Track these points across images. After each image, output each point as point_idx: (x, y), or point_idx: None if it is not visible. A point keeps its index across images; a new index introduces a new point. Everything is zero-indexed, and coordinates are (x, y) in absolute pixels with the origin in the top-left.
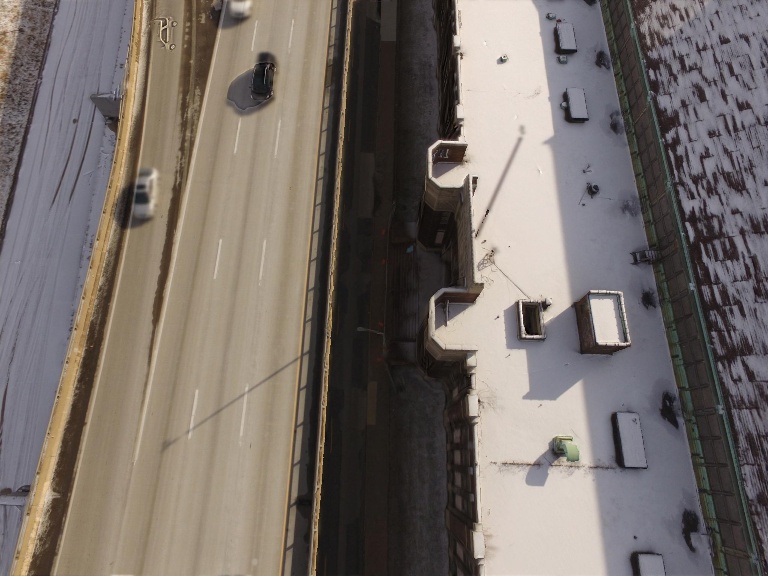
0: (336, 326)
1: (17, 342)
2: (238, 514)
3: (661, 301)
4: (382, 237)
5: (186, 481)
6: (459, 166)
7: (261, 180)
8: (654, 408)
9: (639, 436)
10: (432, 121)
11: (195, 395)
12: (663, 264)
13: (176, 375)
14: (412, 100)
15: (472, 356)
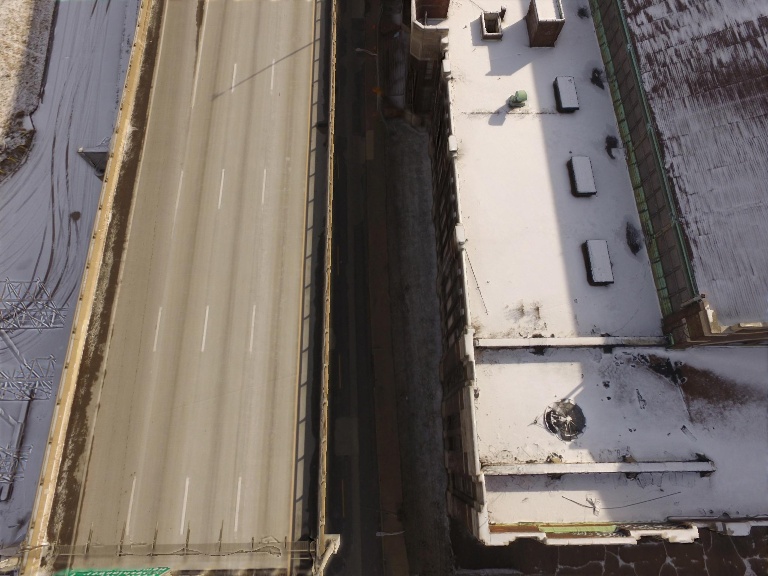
0: (338, 94)
1: (73, 113)
2: (273, 133)
3: (592, 12)
4: (373, 30)
5: (232, 116)
6: None
7: None
8: (586, 78)
9: (573, 90)
10: None
11: (234, 67)
12: None
13: (218, 56)
14: None
15: (445, 37)
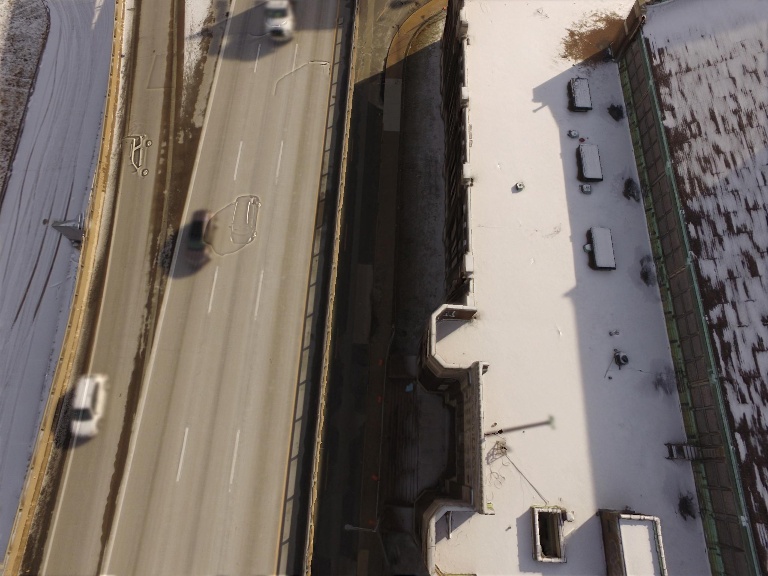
0: (324, 479)
1: None
2: None
3: (702, 511)
4: (379, 369)
5: None
6: (467, 324)
7: (237, 349)
8: None
9: None
10: (437, 228)
11: None
12: (704, 465)
13: None
14: (416, 203)
15: None
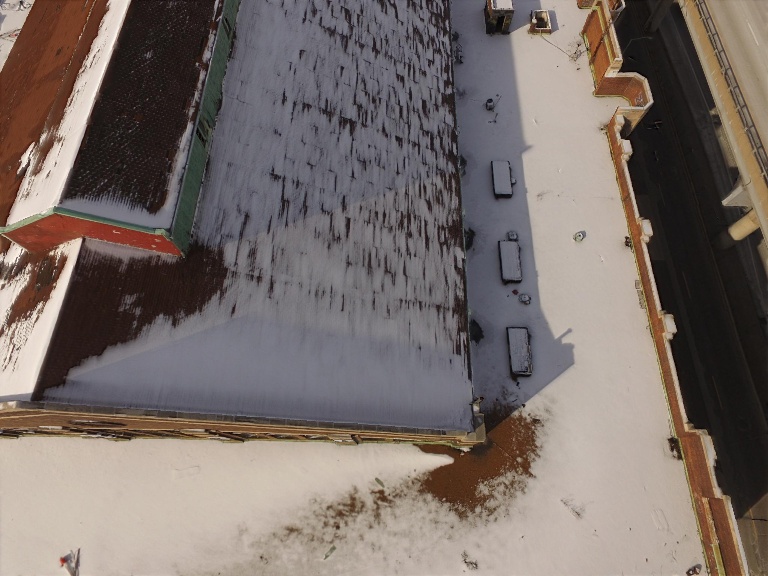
0: None
1: None
2: None
3: None
4: None
5: None
6: None
7: None
8: None
9: None
10: None
11: None
12: None
13: None
14: None
15: None
